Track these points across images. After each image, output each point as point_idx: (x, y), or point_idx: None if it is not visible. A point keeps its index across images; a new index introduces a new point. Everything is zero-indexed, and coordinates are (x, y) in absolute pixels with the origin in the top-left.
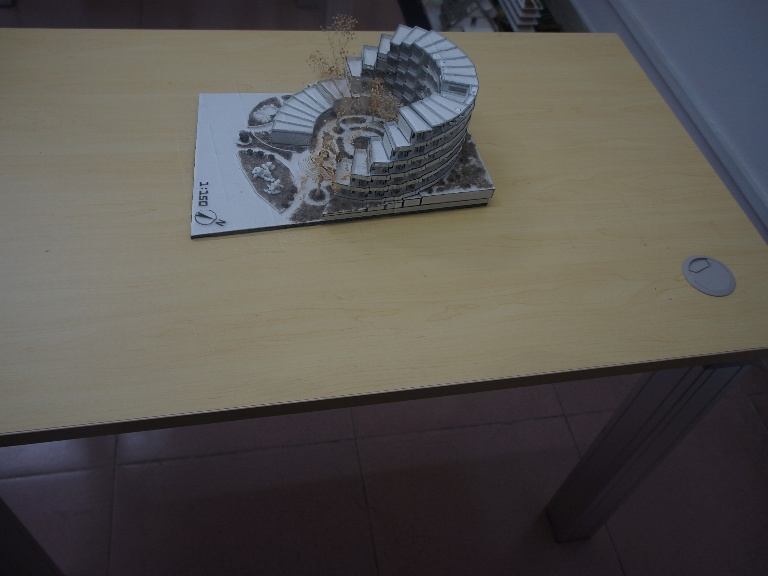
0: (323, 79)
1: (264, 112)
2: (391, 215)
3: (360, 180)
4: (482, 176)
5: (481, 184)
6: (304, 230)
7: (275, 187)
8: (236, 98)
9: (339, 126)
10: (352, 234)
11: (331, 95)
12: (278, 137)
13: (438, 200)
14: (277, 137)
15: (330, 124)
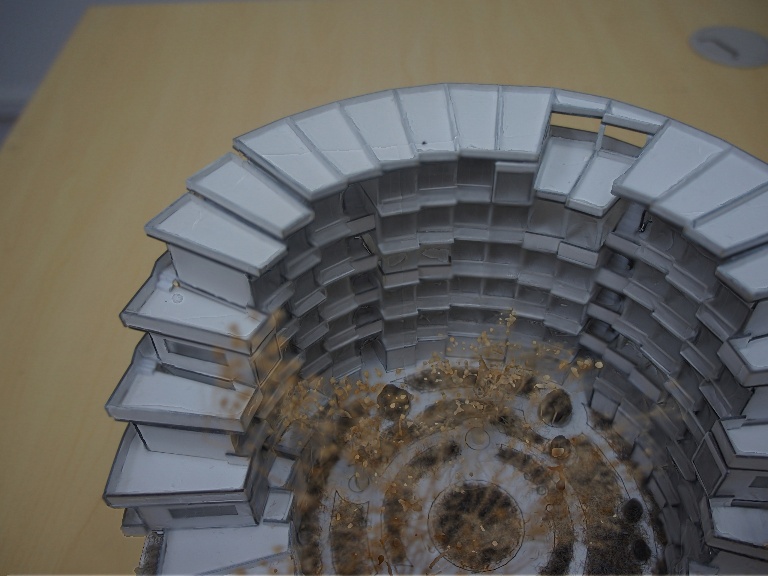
0: None
1: None
2: None
3: None
4: None
5: None
6: None
7: None
8: None
9: None
10: None
11: None
12: None
13: None
14: None
15: None
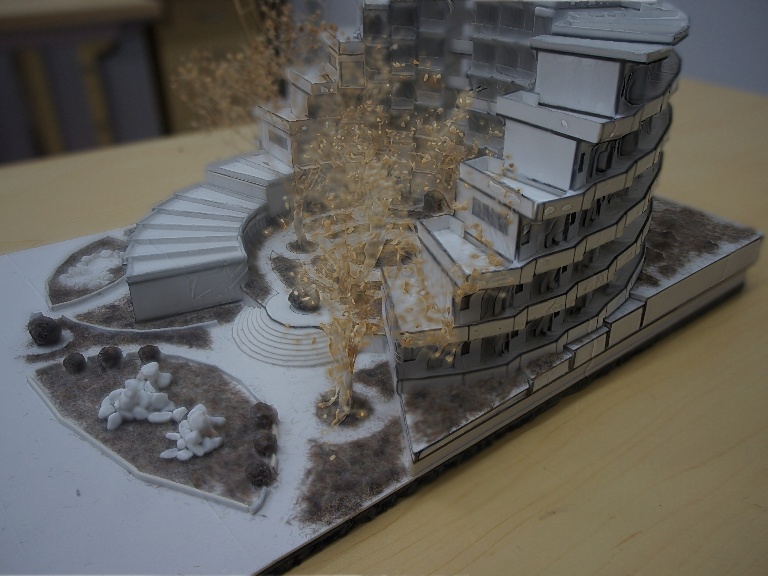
0: None
1: (89, 267)
2: (579, 386)
3: (482, 299)
4: (708, 222)
5: (729, 234)
6: (366, 540)
7: (199, 429)
8: (1, 264)
9: (303, 233)
10: (526, 486)
11: (253, 177)
12: (151, 298)
13: (672, 301)
14: (148, 299)
15: (274, 241)
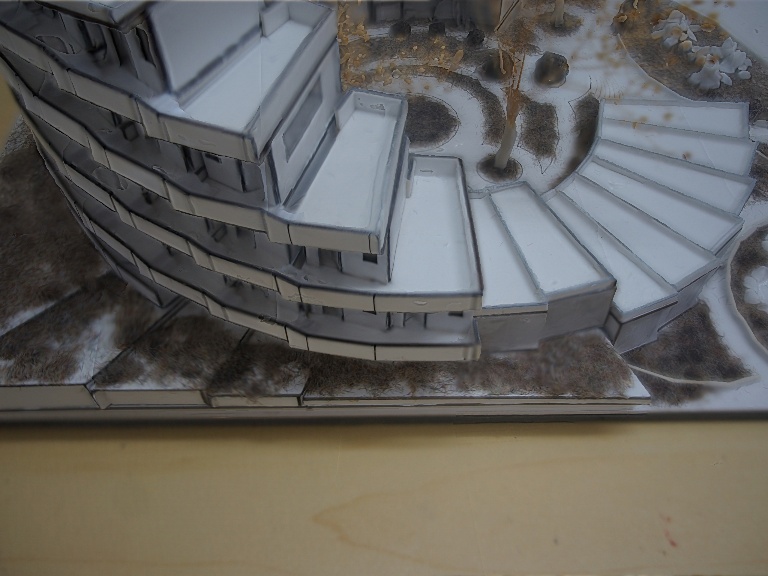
0: (563, 575)
1: None
2: None
3: None
4: None
5: None
6: None
7: None
8: None
9: None
10: None
11: None
12: None
13: None
14: None
15: None
